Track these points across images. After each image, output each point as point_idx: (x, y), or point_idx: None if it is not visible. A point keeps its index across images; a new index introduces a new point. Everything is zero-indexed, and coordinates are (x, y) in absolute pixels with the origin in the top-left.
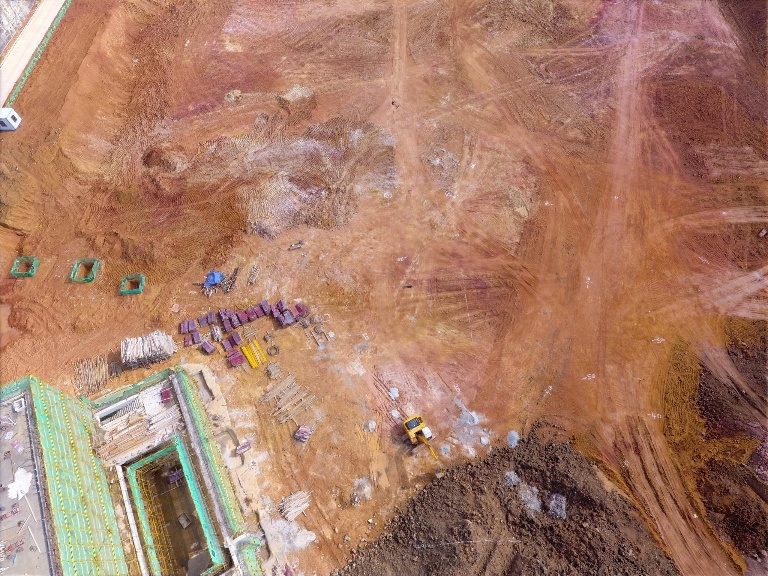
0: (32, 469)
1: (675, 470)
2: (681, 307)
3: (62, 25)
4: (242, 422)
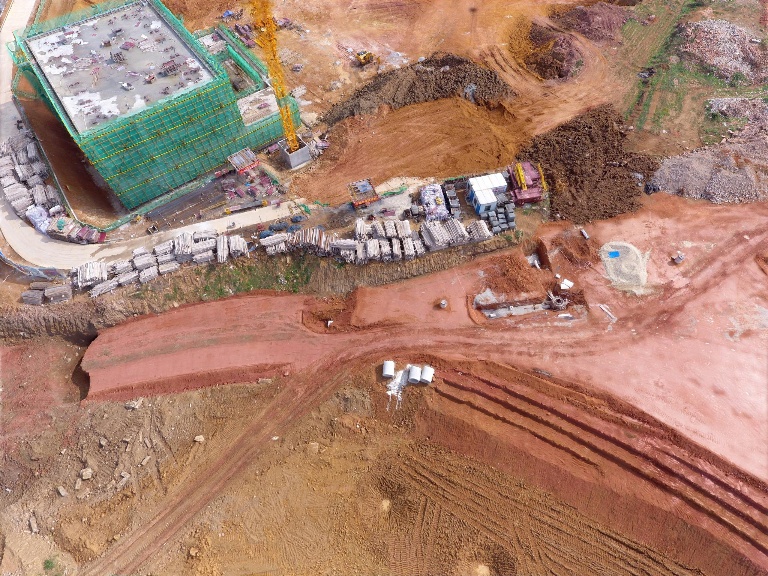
0: (160, 20)
1: (512, 58)
2: (523, 3)
3: None
4: None
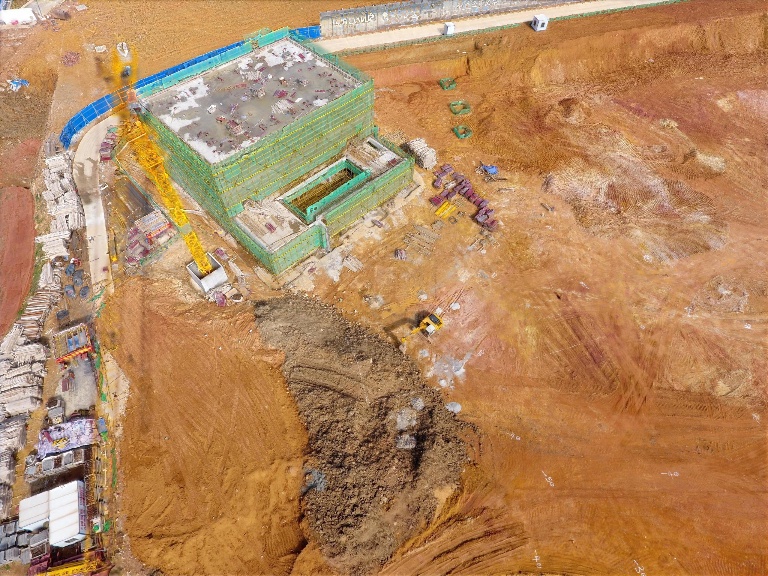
0: None
1: None
2: None
3: (643, 9)
4: (395, 218)
